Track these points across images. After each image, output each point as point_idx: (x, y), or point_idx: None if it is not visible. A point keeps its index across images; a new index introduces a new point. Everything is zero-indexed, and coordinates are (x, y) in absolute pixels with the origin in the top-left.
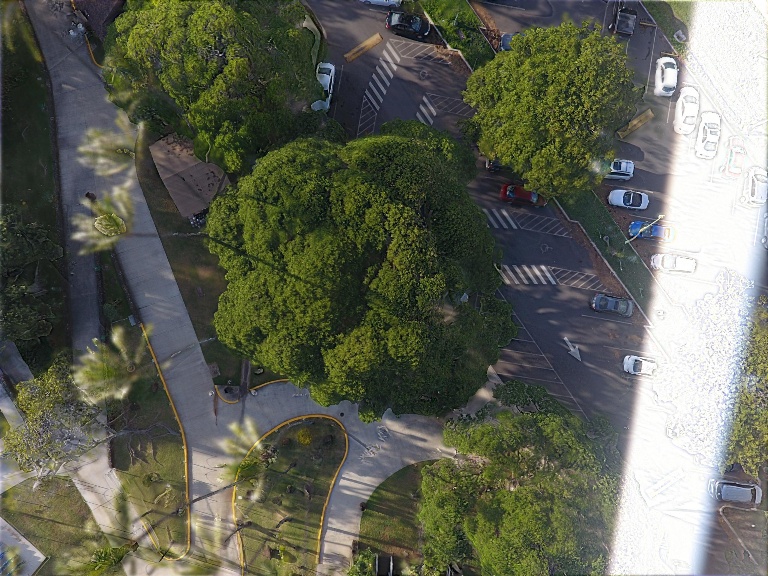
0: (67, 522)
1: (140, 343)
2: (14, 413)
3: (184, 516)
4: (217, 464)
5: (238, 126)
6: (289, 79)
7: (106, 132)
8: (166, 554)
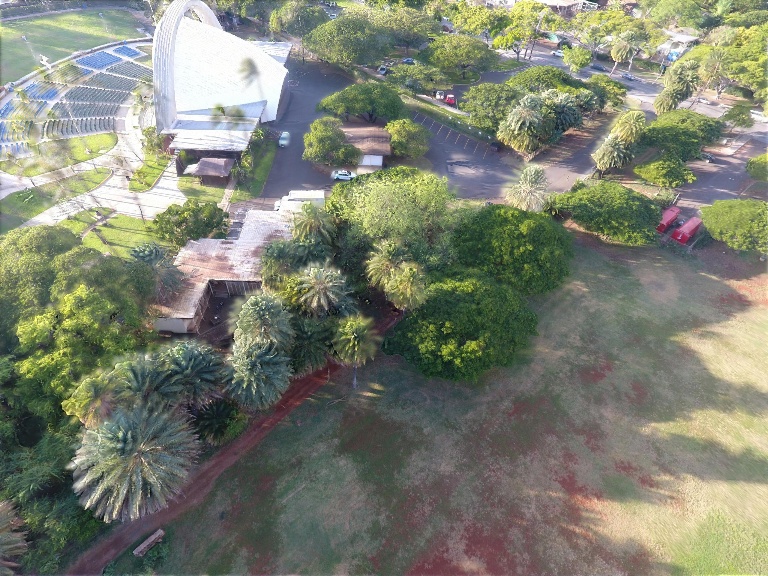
0: None
1: None
2: None
3: None
4: None
5: None
6: None
7: None
8: None
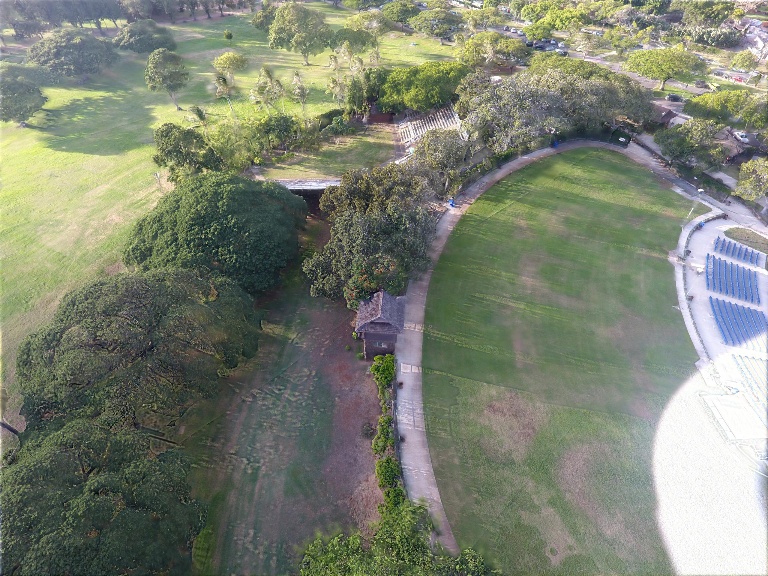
0: (764, 243)
1: None
2: None
3: None
4: None
5: (760, 114)
6: (764, 109)
7: None
8: None
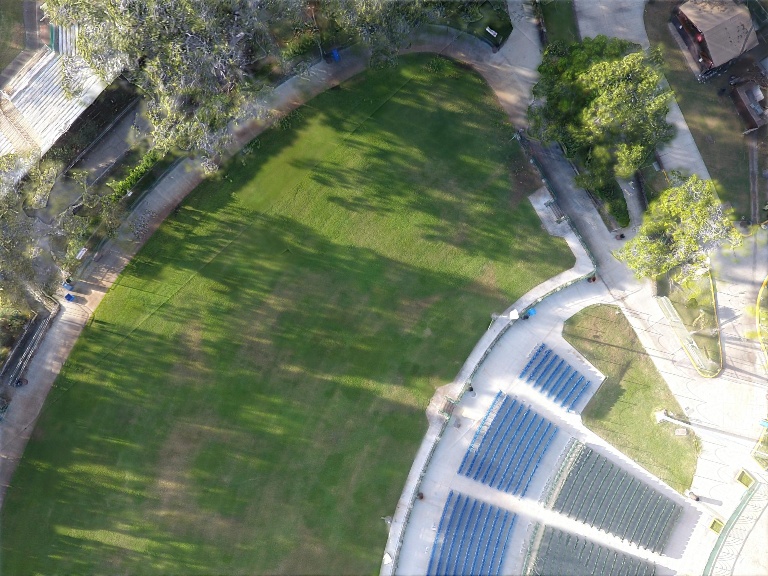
0: (620, 345)
1: (664, 186)
2: (578, 247)
3: (716, 337)
4: (738, 291)
5: None
6: None
7: (617, 4)
8: (704, 372)
